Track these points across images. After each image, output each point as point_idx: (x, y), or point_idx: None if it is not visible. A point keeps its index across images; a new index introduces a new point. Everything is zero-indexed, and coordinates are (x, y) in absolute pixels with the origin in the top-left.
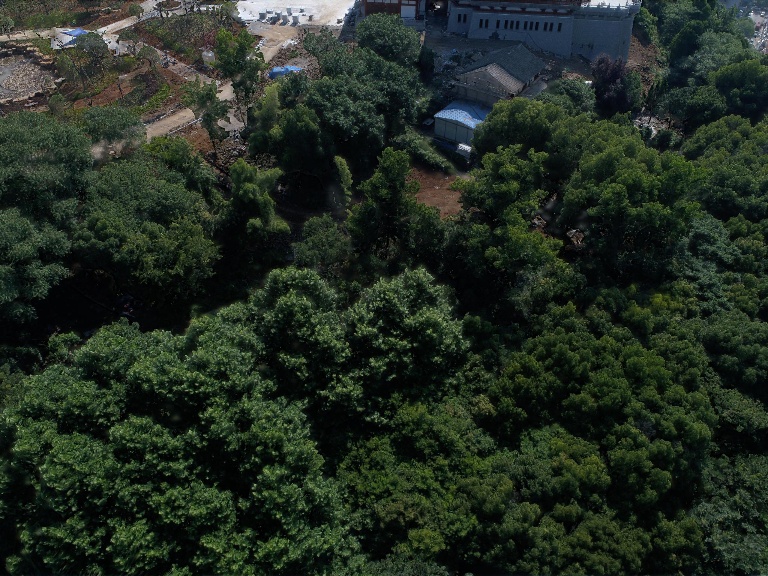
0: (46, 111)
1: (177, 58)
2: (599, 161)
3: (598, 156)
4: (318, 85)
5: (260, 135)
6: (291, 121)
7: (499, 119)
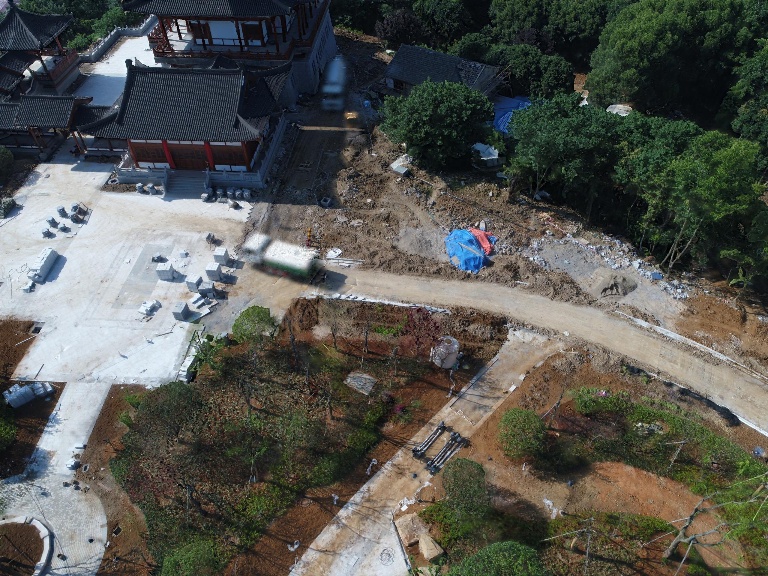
0: None
1: (412, 432)
2: None
3: None
4: (676, 137)
5: (766, 206)
6: None
7: None
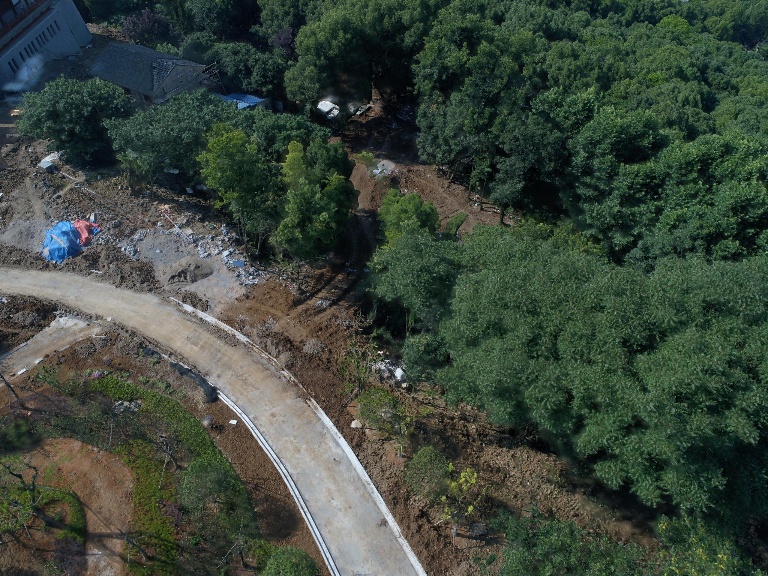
0: (138, 573)
1: None
2: (421, 5)
3: (418, 3)
4: (267, 130)
5: (338, 196)
6: (334, 157)
7: (344, 40)
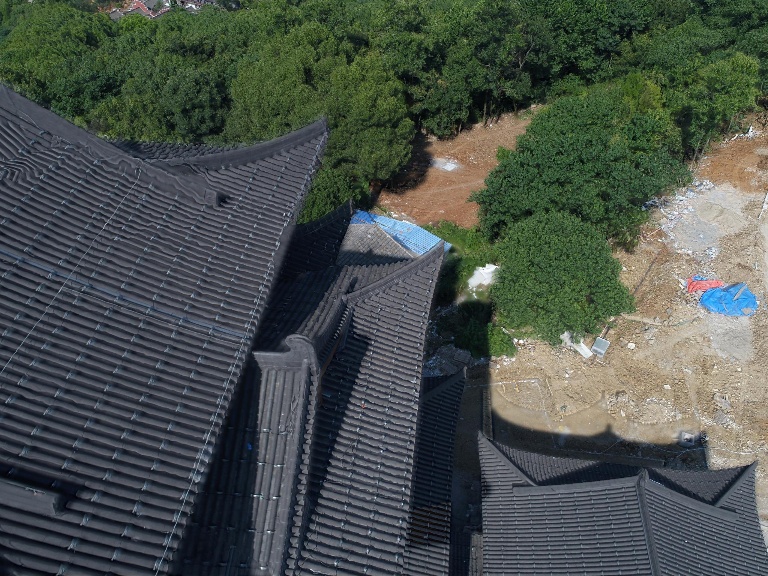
0: None
1: None
2: None
3: None
4: None
5: None
6: None
7: None
